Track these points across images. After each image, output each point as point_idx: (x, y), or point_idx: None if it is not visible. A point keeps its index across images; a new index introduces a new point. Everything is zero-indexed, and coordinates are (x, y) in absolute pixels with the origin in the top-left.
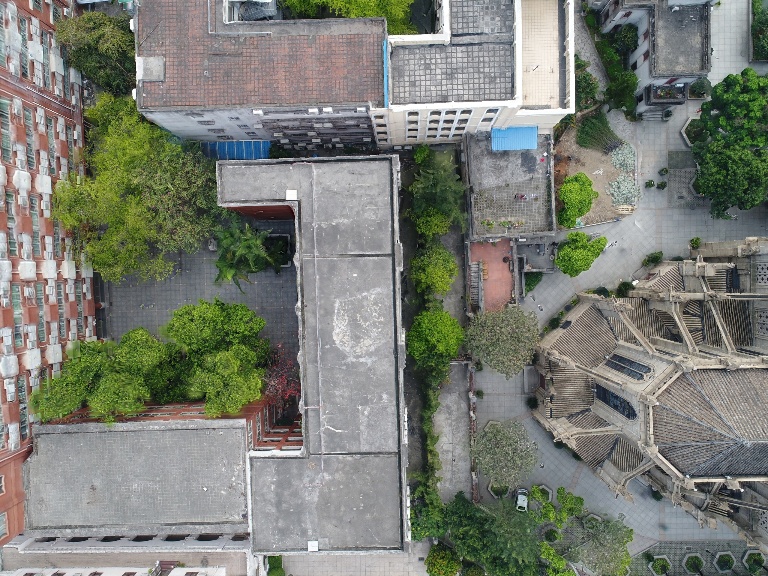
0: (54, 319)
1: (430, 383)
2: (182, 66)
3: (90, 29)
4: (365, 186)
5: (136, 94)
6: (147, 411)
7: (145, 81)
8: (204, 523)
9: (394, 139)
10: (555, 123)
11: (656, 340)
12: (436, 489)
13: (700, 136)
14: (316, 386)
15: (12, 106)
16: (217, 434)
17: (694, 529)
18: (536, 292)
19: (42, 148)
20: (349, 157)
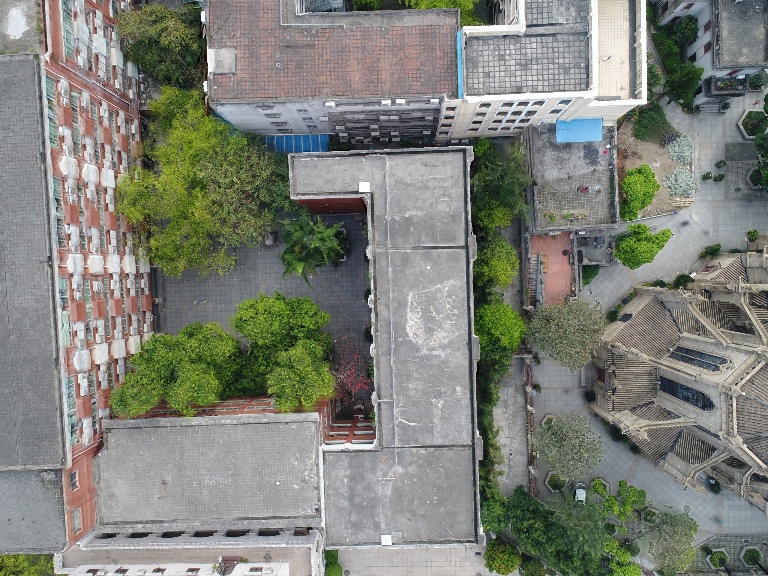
0: (119, 314)
1: (491, 377)
2: (253, 58)
3: (152, 22)
4: (438, 178)
5: (207, 86)
6: (211, 406)
7: (216, 73)
8: (276, 517)
9: (455, 132)
10: (621, 115)
11: (721, 332)
12: (498, 483)
13: (757, 128)
14: (389, 379)
15: (81, 99)
16: (289, 428)
17: (752, 522)
18: (593, 285)
19: (107, 142)
20: (423, 149)
